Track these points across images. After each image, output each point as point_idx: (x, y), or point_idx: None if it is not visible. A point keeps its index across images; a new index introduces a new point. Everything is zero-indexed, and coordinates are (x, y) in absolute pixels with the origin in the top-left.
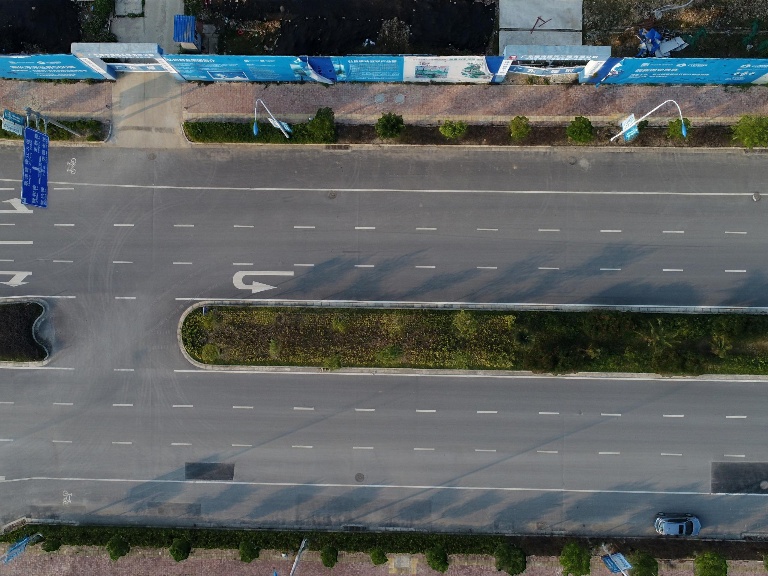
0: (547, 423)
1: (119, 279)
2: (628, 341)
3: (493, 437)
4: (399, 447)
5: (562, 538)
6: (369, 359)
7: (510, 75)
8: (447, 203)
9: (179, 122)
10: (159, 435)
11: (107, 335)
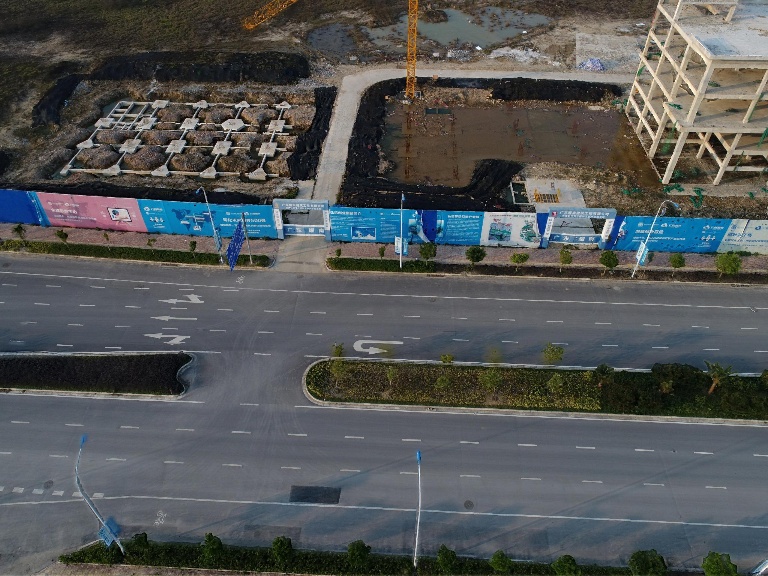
0: (645, 459)
1: (260, 342)
2: (694, 388)
3: (597, 470)
4: (506, 476)
5: (699, 573)
6: (471, 400)
7: (551, 245)
8: (520, 306)
9: (323, 260)
10: (270, 459)
11: (241, 379)
